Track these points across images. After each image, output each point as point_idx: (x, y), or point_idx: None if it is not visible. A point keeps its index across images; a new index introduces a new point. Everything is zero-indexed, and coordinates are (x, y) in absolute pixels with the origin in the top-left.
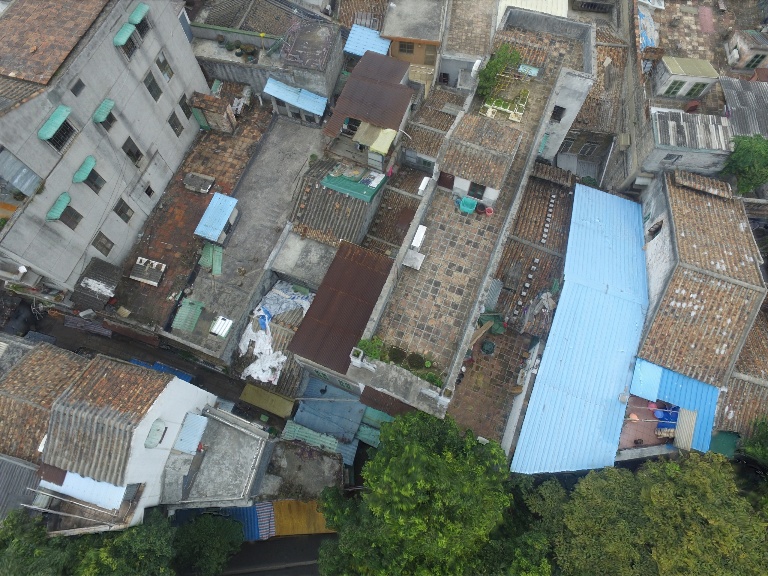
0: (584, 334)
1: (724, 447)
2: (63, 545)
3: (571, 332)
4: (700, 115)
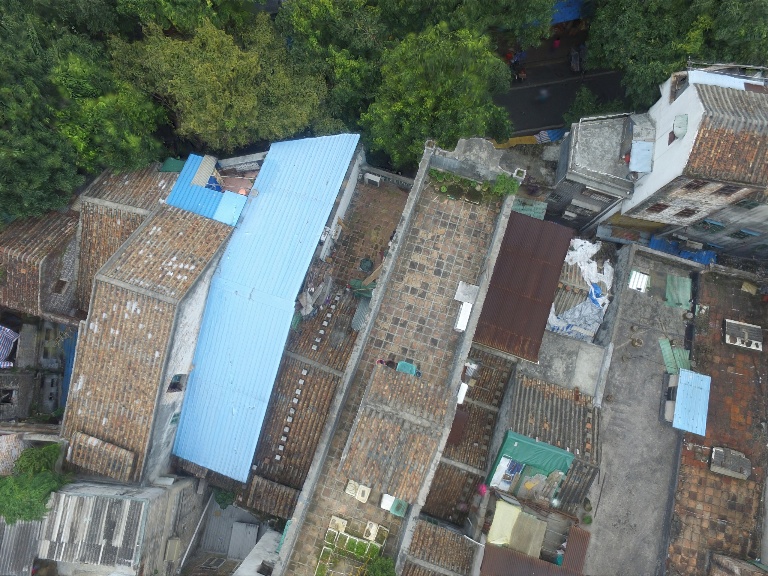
0: (282, 248)
1: (173, 164)
2: (719, 59)
3: (294, 250)
4: (74, 560)
